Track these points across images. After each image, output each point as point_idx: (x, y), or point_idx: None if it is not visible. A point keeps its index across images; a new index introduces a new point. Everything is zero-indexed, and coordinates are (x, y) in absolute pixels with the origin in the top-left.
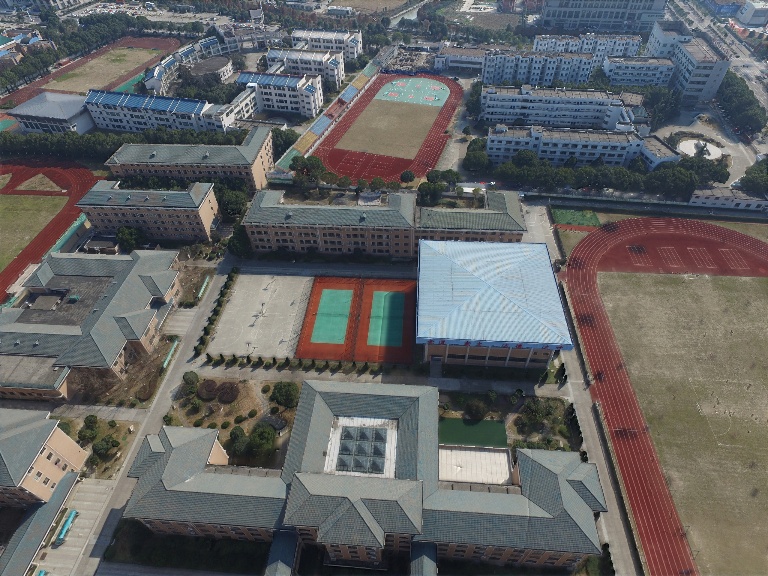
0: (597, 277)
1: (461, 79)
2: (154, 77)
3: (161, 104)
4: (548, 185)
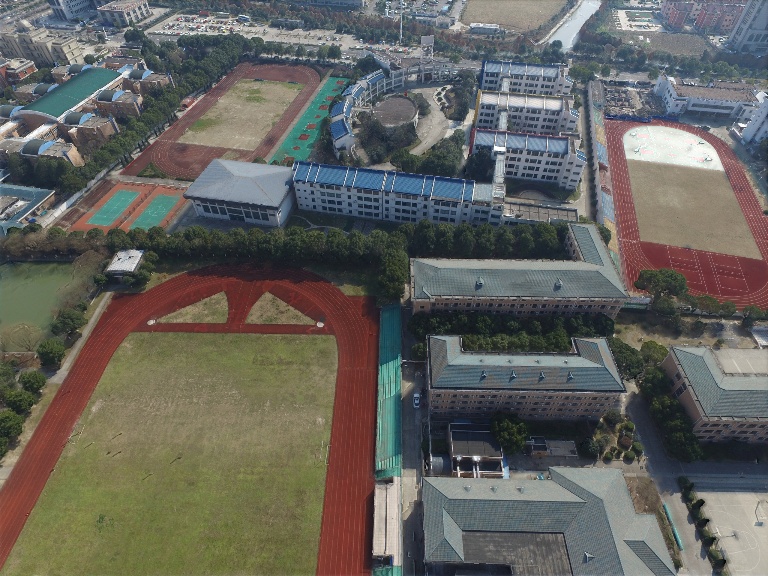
0: None
1: (711, 128)
2: (348, 133)
3: (408, 185)
4: None
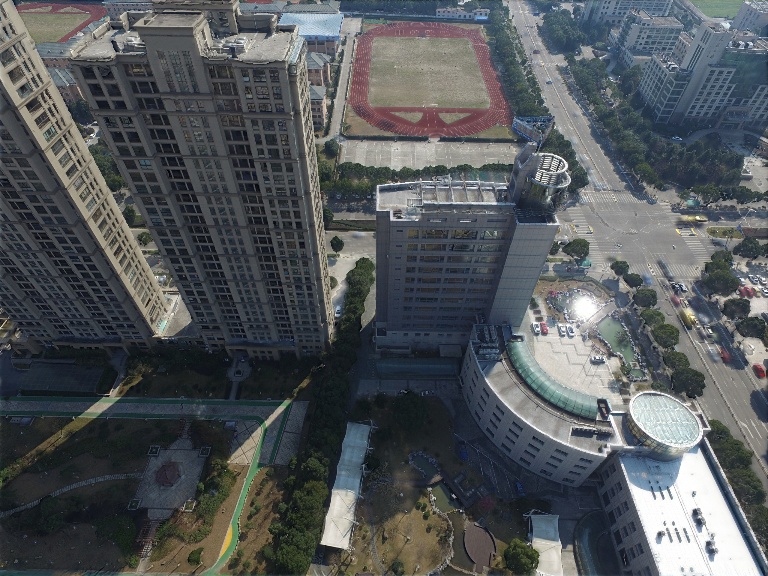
0: (374, 38)
1: None
2: None
3: None
4: (363, 6)
